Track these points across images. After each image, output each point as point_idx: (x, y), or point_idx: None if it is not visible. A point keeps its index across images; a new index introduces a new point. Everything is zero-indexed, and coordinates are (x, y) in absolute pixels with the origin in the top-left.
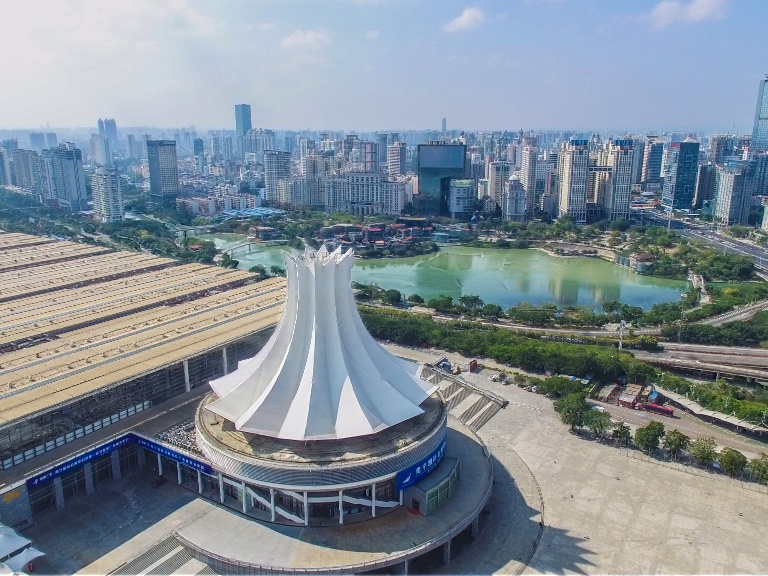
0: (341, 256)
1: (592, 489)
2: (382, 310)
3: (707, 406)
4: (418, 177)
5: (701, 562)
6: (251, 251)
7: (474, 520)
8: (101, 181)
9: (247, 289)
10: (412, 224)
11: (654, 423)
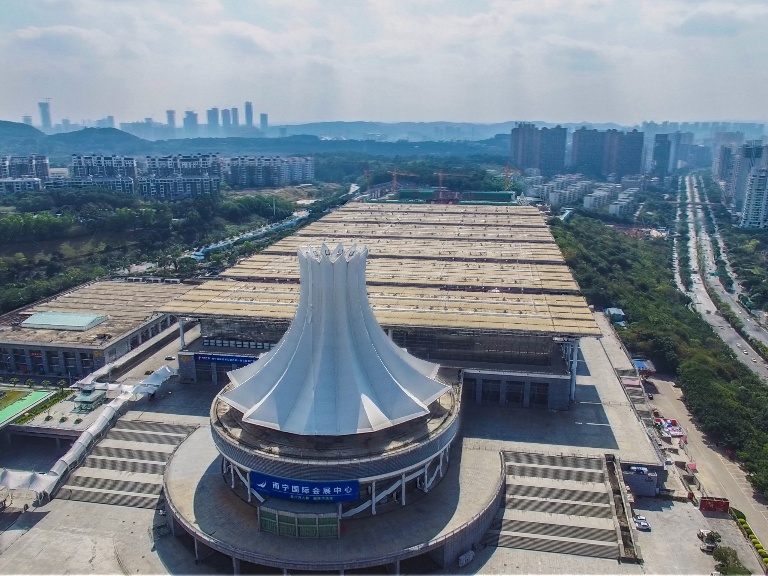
0: None
1: None
2: None
3: None
4: None
5: None
6: None
7: (280, 569)
8: (749, 182)
9: (519, 296)
10: None
11: None
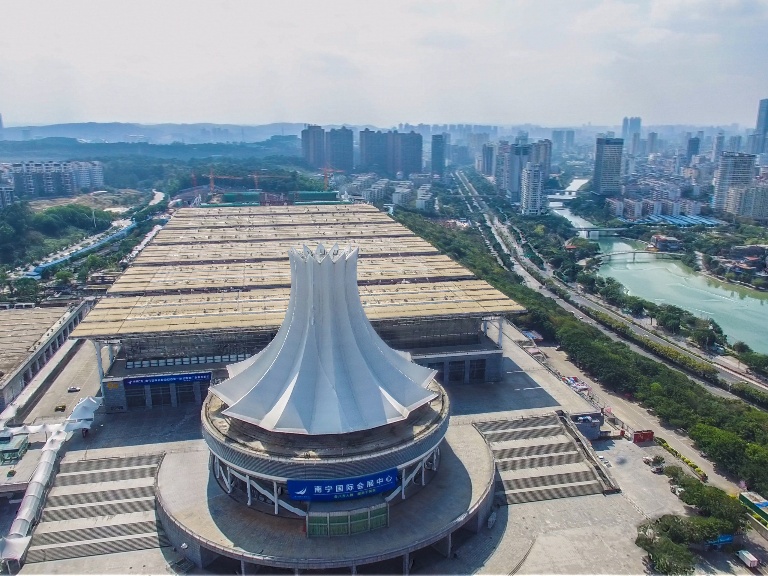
0: None
1: None
2: (663, 348)
3: None
4: None
5: None
6: (635, 260)
7: (348, 568)
8: (526, 176)
9: (432, 285)
10: None
11: None
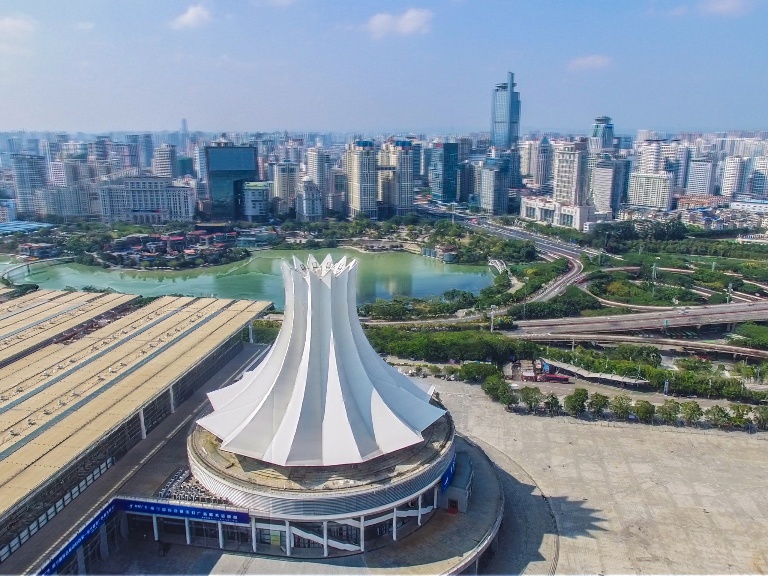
0: (335, 265)
1: (559, 457)
2: None
3: (591, 369)
4: (209, 181)
5: (674, 497)
6: (30, 272)
7: None
8: None
9: (143, 313)
10: (213, 230)
11: (579, 390)
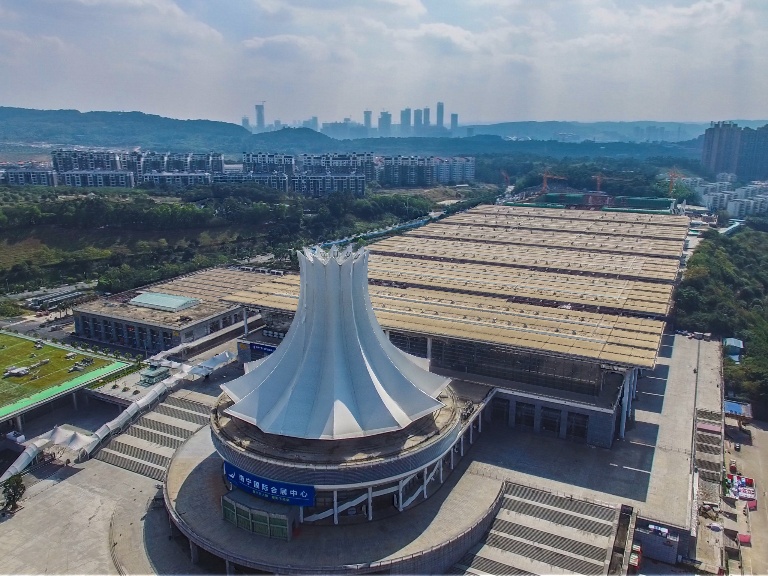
0: None
1: None
2: None
3: None
4: None
5: None
6: None
7: None
8: None
9: (587, 315)
10: None
11: None
